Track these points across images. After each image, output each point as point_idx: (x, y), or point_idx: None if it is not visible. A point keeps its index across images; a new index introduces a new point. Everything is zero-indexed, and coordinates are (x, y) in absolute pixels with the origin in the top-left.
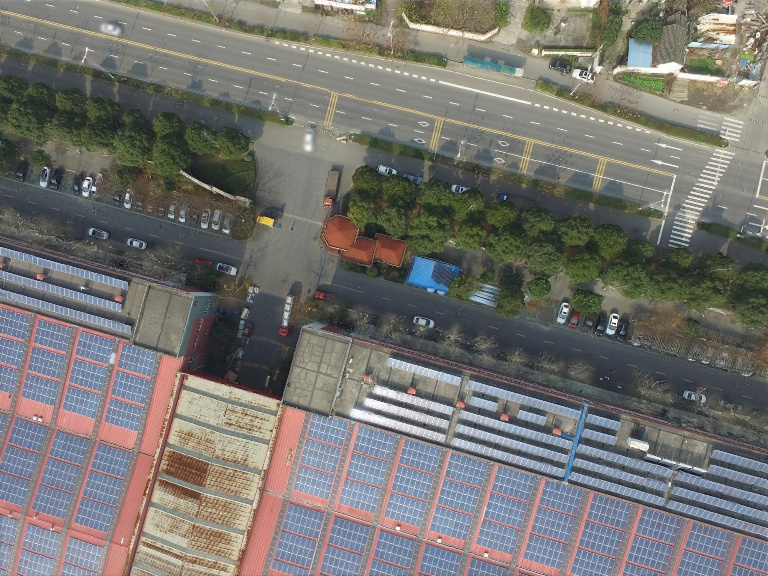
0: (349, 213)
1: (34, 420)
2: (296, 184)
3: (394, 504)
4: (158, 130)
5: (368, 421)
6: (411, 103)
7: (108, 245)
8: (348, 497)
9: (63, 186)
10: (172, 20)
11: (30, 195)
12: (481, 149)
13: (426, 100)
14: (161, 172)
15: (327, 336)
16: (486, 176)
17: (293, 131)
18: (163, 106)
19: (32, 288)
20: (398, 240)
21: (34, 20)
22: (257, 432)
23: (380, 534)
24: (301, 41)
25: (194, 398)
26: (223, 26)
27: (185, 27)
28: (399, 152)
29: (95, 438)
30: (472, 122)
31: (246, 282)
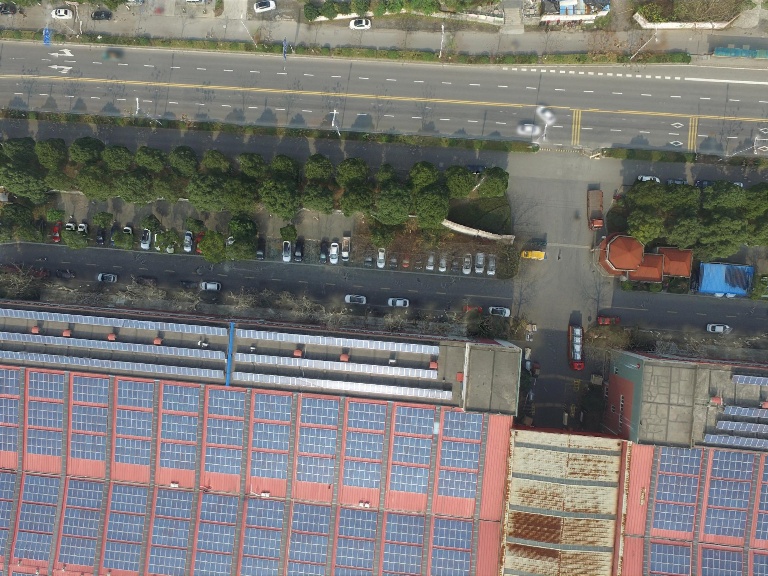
0: (639, 232)
1: (360, 507)
2: (554, 211)
3: (764, 524)
4: (418, 182)
5: (722, 444)
6: (660, 106)
7: (369, 309)
8: (713, 526)
9: (306, 257)
10: (388, 64)
11: (273, 272)
12: (742, 140)
13: (675, 100)
14: (430, 225)
15: (671, 365)
16: (754, 167)
17: (540, 157)
18: (396, 155)
19: (334, 371)
20: (684, 250)
21: (241, 90)
22: (603, 476)
23: (754, 557)
24: (533, 62)
25: (529, 453)
26: (445, 61)
27: (404, 69)
28: (659, 159)
29: (430, 514)
30: (728, 114)
31: (523, 321)
